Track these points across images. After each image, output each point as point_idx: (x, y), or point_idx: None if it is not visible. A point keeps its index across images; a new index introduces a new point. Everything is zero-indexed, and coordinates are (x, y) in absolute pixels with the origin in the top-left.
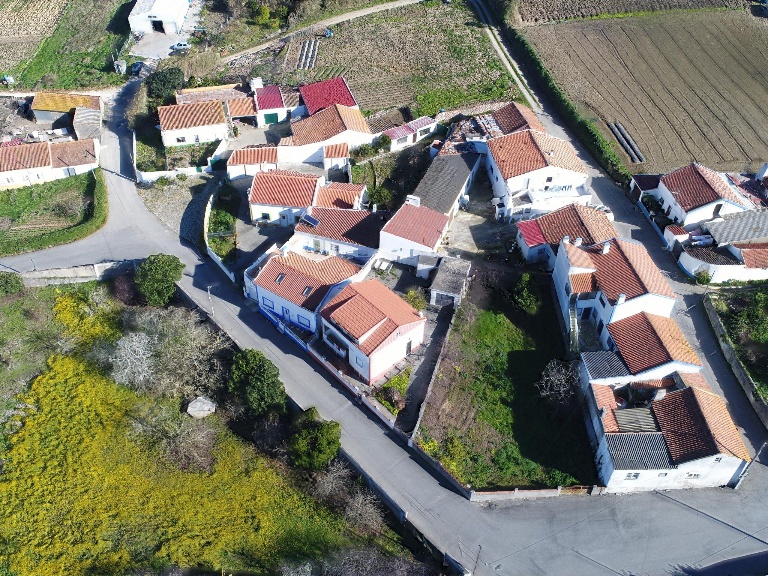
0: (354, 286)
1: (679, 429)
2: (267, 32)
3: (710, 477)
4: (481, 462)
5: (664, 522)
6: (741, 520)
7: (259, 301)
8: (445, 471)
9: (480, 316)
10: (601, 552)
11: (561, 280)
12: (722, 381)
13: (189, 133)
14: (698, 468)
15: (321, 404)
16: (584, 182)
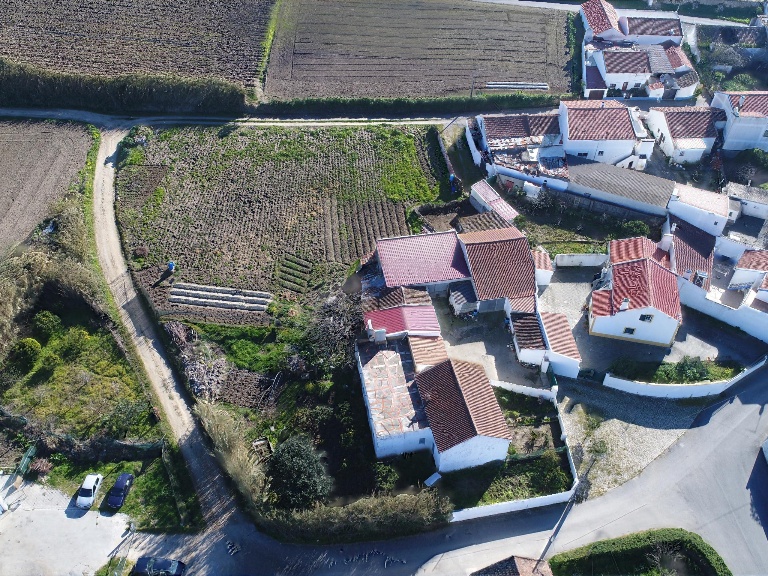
0: None
1: None
2: (94, 354)
3: None
4: None
5: None
6: None
7: None
8: None
9: None
10: None
11: (750, 137)
12: None
13: None
14: None
15: None
16: None
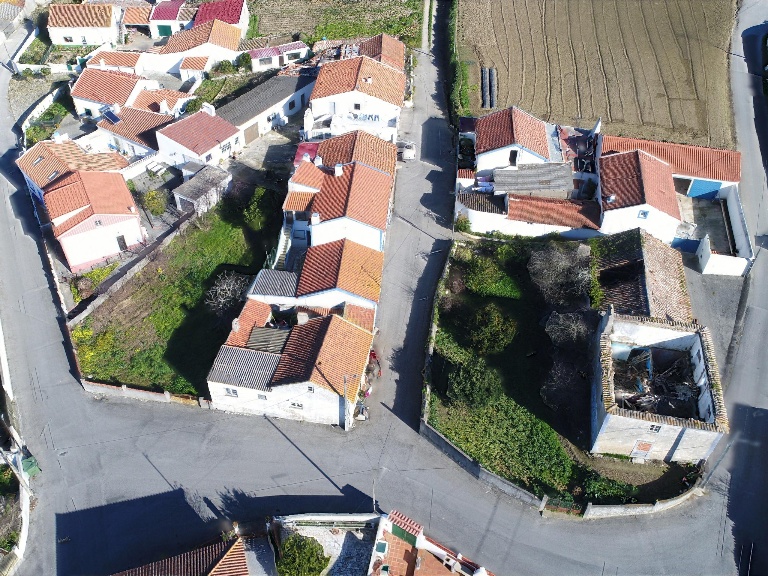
0: (83, 173)
1: (297, 354)
2: None
3: (316, 410)
4: (119, 358)
5: (250, 446)
6: (329, 461)
7: (27, 183)
8: (76, 358)
9: (216, 227)
10: (168, 461)
11: None
12: (412, 326)
13: (75, 33)
14: (296, 396)
15: (21, 282)
16: (397, 115)
